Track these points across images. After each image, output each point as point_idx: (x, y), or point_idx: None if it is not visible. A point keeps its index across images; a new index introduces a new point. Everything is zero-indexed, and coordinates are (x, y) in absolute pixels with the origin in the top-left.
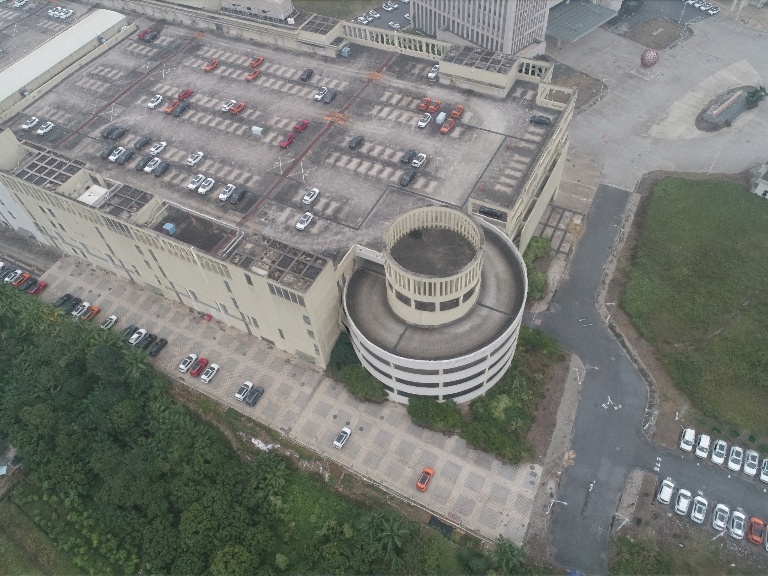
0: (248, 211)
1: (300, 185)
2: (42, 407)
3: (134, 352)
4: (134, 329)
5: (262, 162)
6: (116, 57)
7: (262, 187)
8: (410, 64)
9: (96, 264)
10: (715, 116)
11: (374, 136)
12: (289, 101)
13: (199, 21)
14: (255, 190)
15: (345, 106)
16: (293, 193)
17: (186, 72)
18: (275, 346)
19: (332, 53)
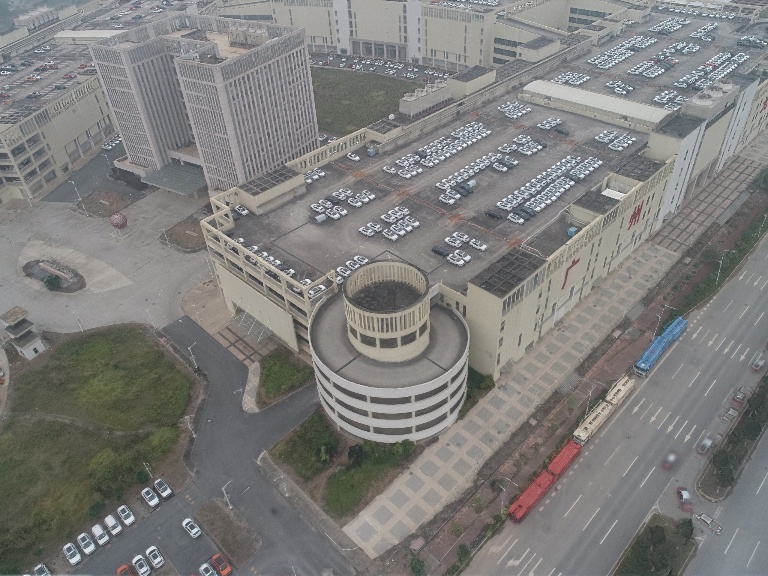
0: None
1: None
2: None
3: None
4: None
5: None
6: None
7: None
8: None
9: None
10: (40, 267)
11: None
12: None
13: None
14: None
15: None
16: None
17: None
18: None
19: None
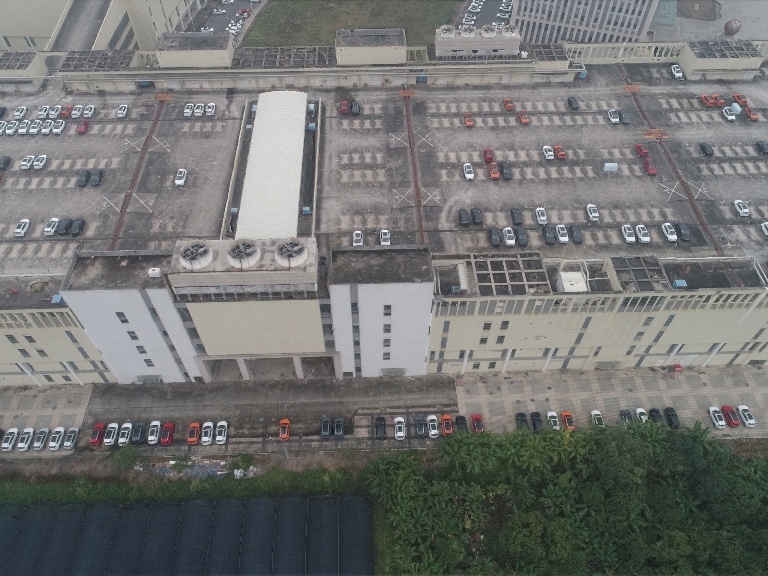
0: (707, 242)
1: (714, 203)
2: (680, 532)
3: (686, 430)
4: (630, 413)
5: (652, 194)
6: (345, 140)
7: (685, 216)
8: (644, 70)
9: (505, 370)
10: None
11: (707, 140)
12: (591, 132)
13: (394, 79)
14: (683, 221)
15: (645, 122)
16: (718, 212)
17: (448, 134)
18: (762, 364)
19: (570, 77)
